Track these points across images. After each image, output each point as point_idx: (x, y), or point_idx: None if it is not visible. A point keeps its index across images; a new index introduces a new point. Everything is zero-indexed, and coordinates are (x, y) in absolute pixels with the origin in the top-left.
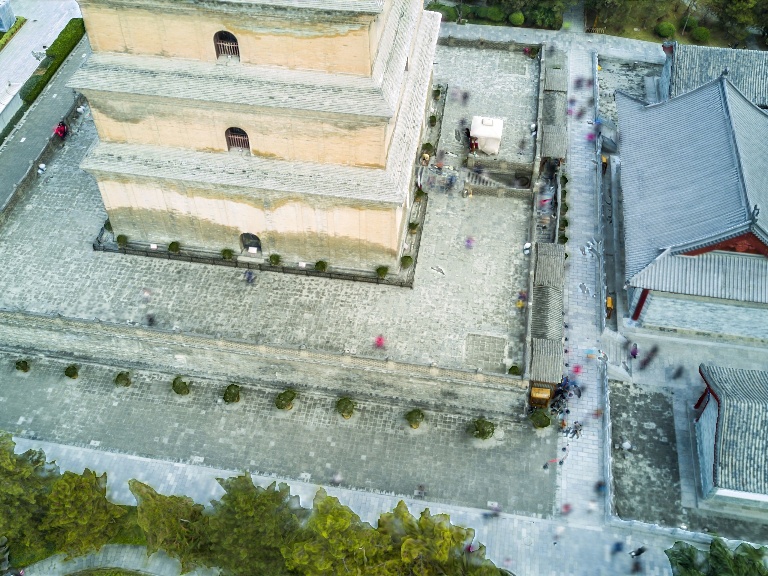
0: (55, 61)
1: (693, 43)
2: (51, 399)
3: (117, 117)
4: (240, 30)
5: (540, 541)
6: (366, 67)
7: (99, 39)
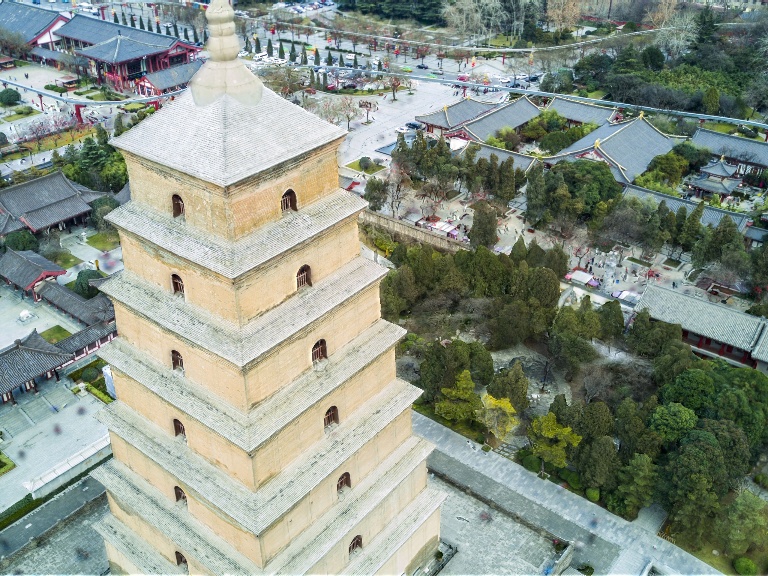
0: None
1: None
2: None
3: (120, 505)
4: (188, 492)
5: None
6: (259, 561)
7: (118, 452)
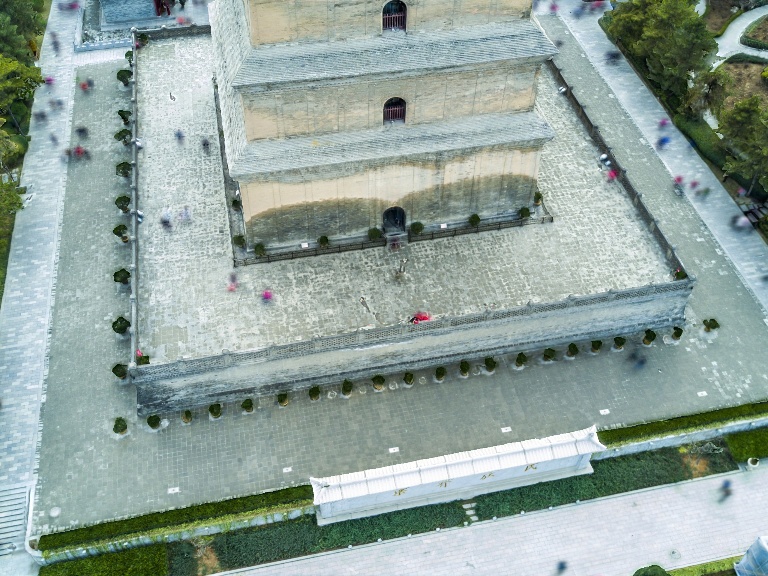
0: (210, 511)
1: (41, 12)
2: (671, 232)
3: None
4: None
5: (574, 16)
6: None
7: None
